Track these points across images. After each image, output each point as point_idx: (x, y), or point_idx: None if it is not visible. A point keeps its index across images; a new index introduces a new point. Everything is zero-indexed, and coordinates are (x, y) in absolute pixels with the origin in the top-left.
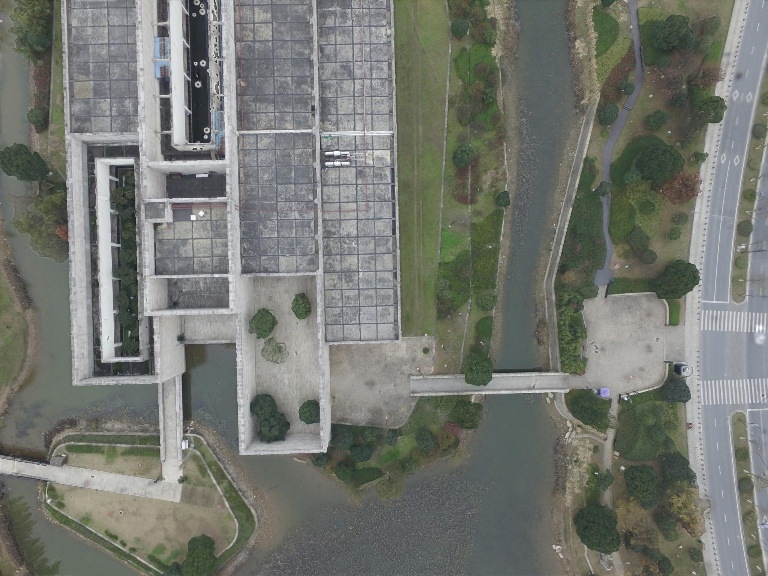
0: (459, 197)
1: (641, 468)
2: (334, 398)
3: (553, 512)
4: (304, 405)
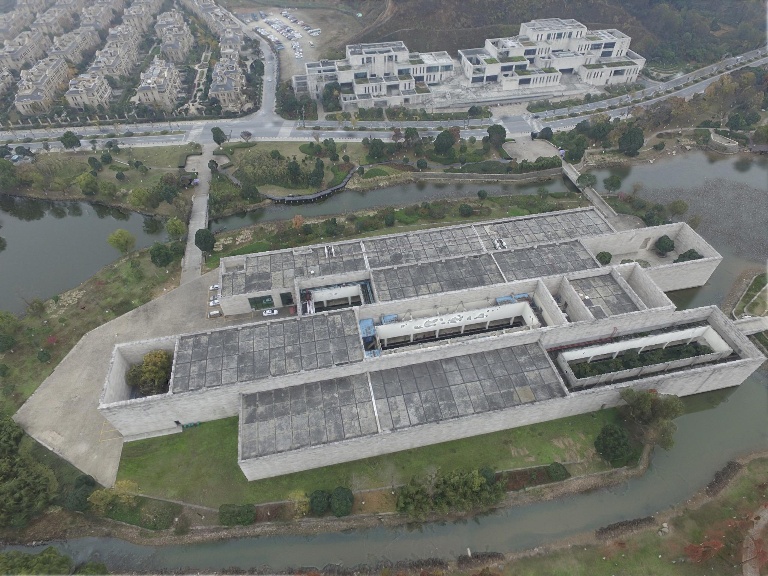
0: (488, 212)
1: (593, 131)
2: (646, 245)
3: (634, 165)
4: (664, 245)
